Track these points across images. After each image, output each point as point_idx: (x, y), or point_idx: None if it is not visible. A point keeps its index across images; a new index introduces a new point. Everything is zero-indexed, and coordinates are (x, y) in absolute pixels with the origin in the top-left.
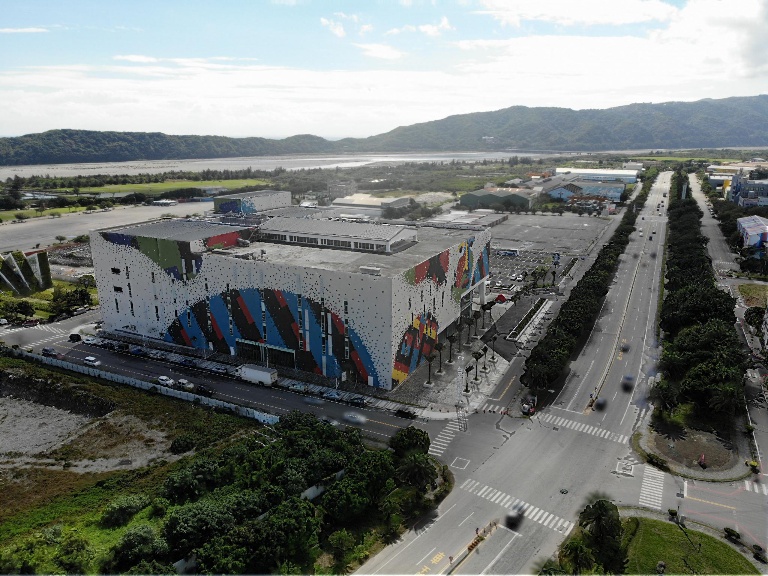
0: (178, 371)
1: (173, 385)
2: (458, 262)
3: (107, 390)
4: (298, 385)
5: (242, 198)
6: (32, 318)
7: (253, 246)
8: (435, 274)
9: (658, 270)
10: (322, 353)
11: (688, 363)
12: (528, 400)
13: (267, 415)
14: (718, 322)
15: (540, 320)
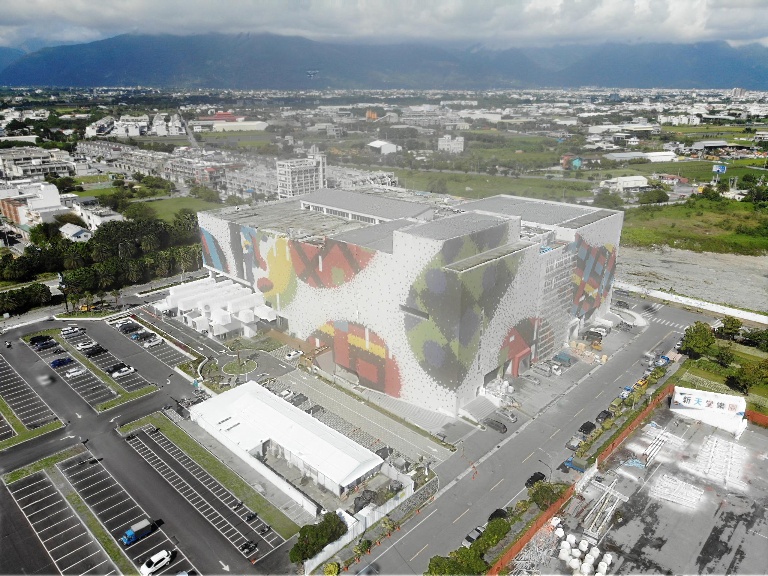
0: None
1: None
2: None
3: None
4: None
5: None
6: (727, 341)
7: None
8: None
9: None
10: None
11: None
12: None
13: None
14: None
15: None
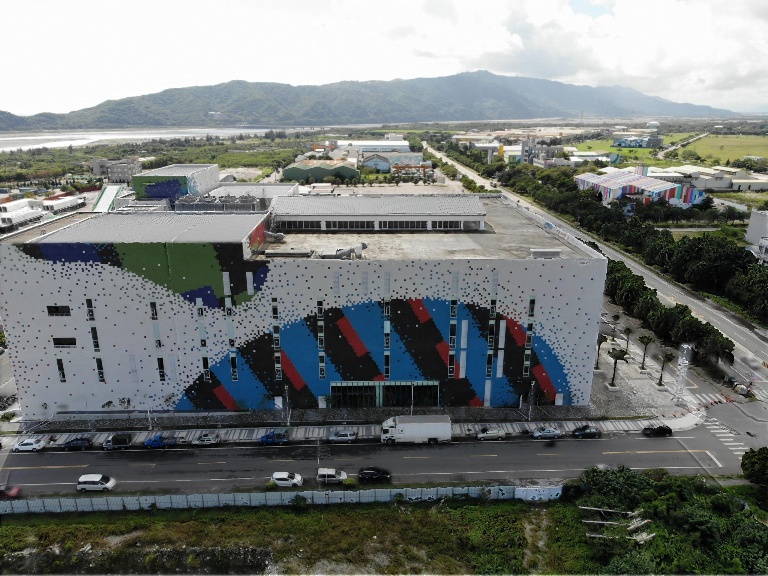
0: (275, 456)
1: (305, 483)
2: None
3: (209, 529)
4: (493, 430)
5: (170, 175)
6: None
7: (292, 241)
8: None
9: (571, 228)
10: (486, 377)
11: None
12: (720, 379)
13: (541, 488)
14: (763, 266)
15: None
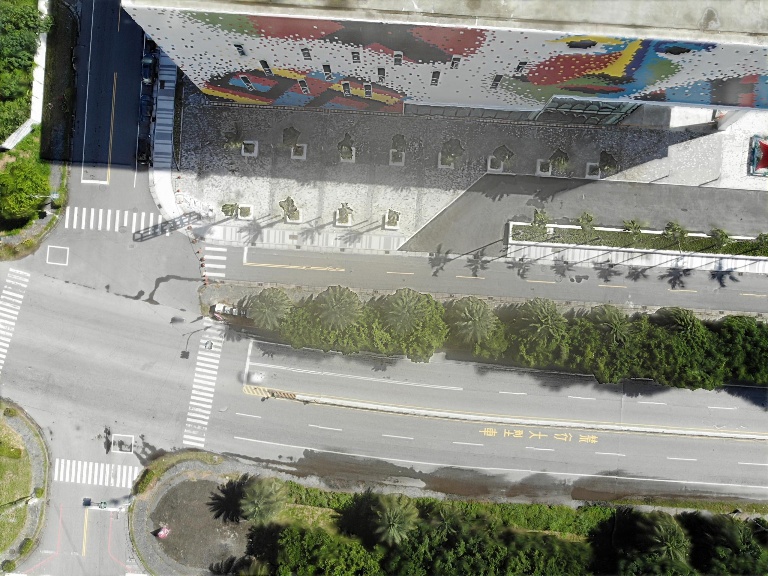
0: None
1: None
2: (552, 55)
3: None
4: None
5: None
6: None
7: None
8: (385, 43)
9: None
10: None
11: (394, 550)
12: None
13: None
14: None
15: (661, 266)
